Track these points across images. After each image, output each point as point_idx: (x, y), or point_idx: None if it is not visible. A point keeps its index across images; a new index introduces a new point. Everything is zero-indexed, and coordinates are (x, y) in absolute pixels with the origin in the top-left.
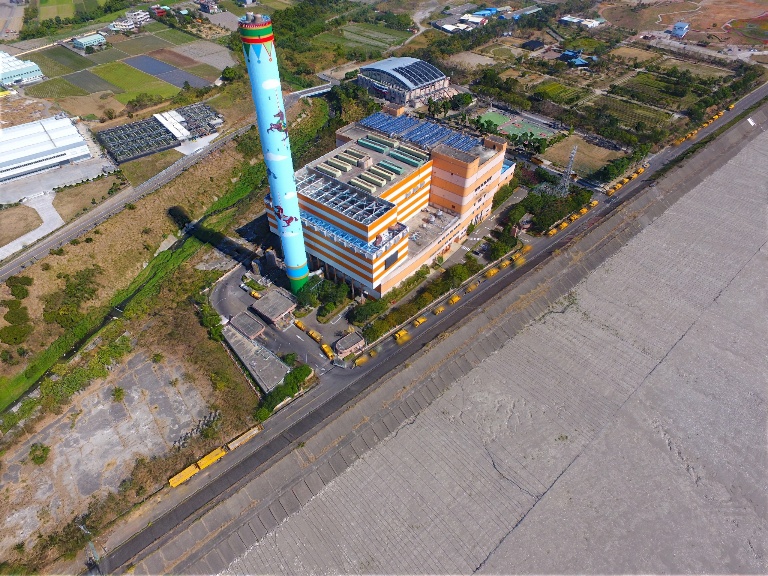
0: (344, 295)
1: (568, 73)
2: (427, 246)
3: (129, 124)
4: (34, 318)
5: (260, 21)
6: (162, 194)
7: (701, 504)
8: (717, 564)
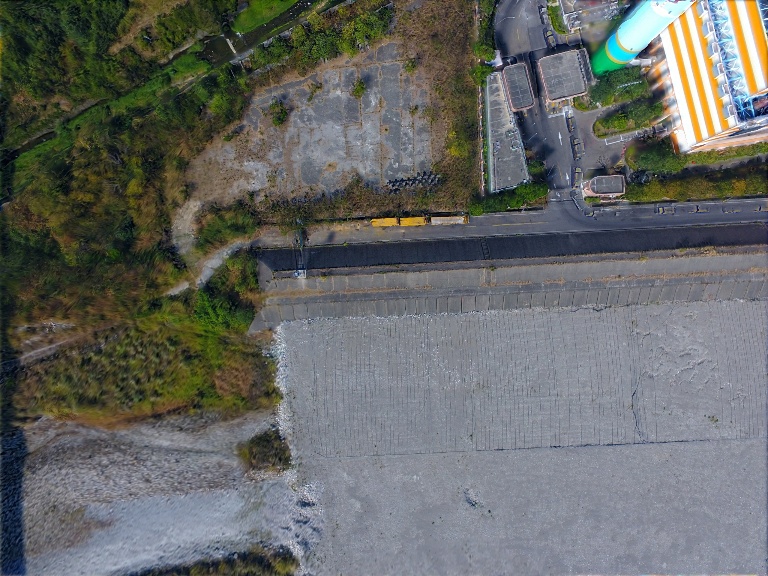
0: None
1: None
2: None
3: None
4: None
5: None
6: None
7: (762, 539)
8: (722, 570)
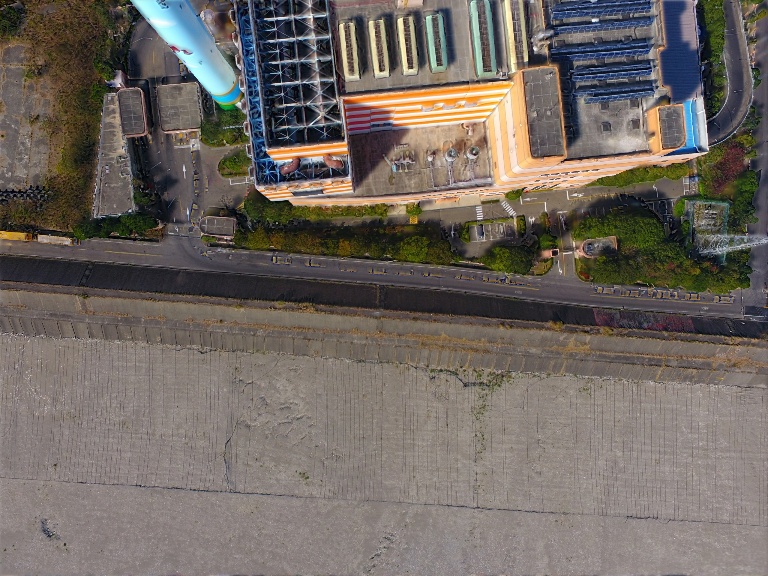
0: None
1: None
2: (395, 195)
3: None
4: None
5: None
6: None
7: None
8: None
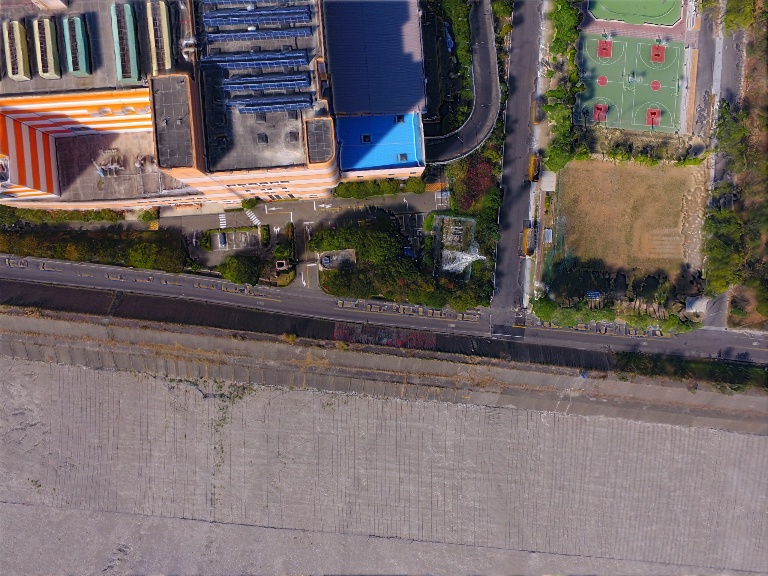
0: None
1: None
2: (102, 200)
3: None
4: None
5: None
6: None
7: None
8: None
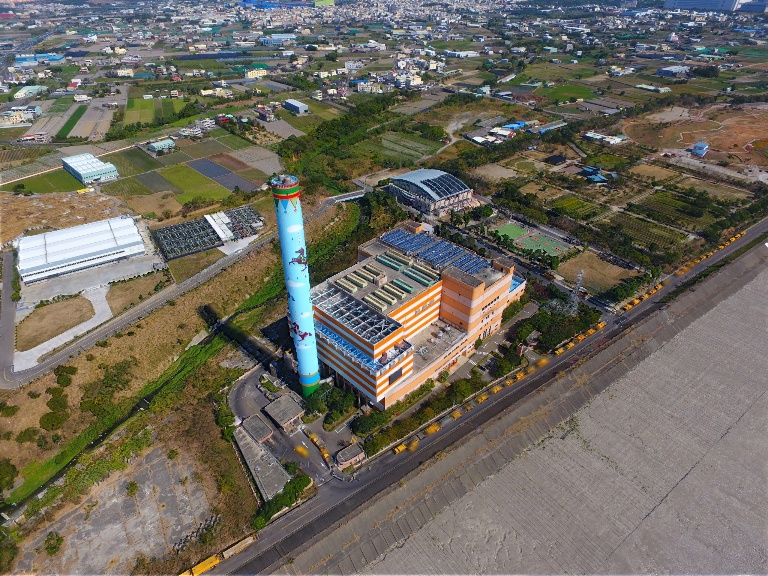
0: (350, 404)
1: (587, 189)
2: (432, 362)
3: (182, 223)
4: (72, 405)
5: (289, 183)
6: (200, 292)
7: None
8: None
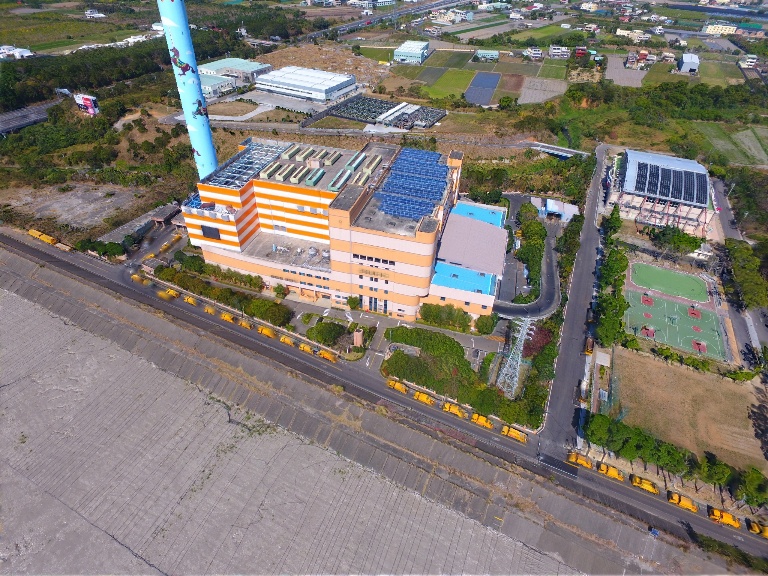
0: None
1: None
2: (265, 259)
3: (382, 100)
4: None
5: None
6: (303, 138)
7: None
8: None
